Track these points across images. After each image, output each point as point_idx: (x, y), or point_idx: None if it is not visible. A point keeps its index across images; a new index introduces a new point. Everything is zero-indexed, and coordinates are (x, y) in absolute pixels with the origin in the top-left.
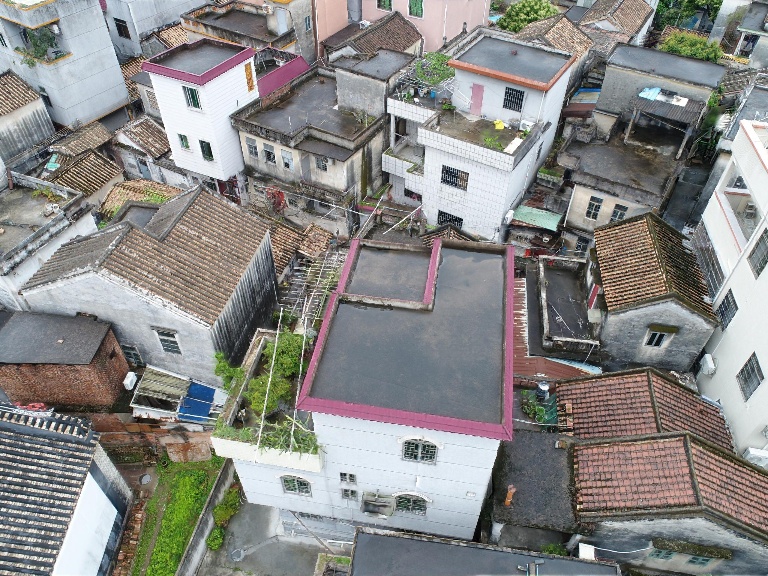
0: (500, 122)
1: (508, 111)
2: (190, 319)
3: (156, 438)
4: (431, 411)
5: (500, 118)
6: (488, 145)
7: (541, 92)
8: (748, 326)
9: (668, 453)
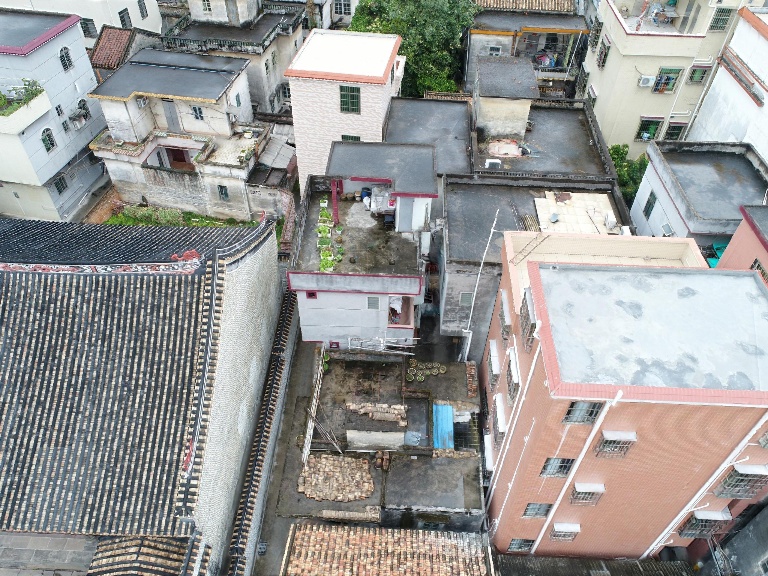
0: None
1: None
2: None
3: None
4: None
5: None
6: None
7: None
8: None
9: (108, 34)
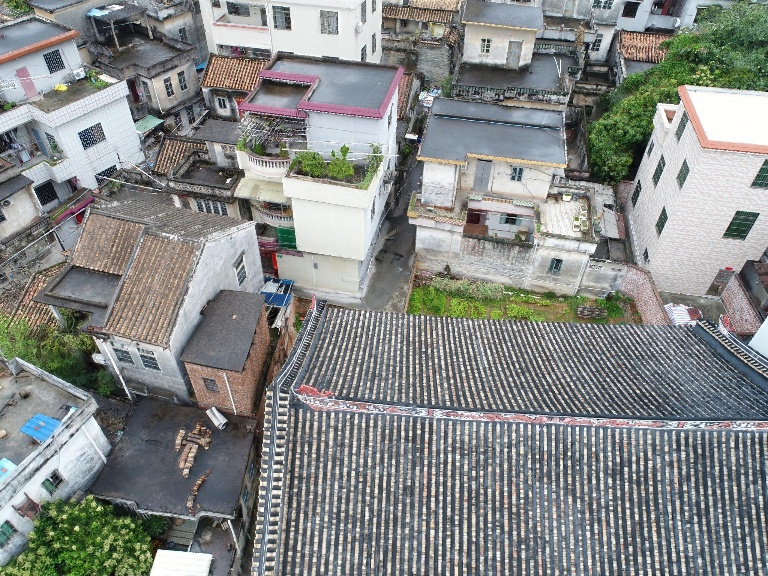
0: (60, 85)
1: (56, 74)
2: (249, 225)
3: (284, 349)
4: (388, 84)
5: (55, 83)
6: (102, 87)
7: (70, 41)
8: (308, 51)
9: None
